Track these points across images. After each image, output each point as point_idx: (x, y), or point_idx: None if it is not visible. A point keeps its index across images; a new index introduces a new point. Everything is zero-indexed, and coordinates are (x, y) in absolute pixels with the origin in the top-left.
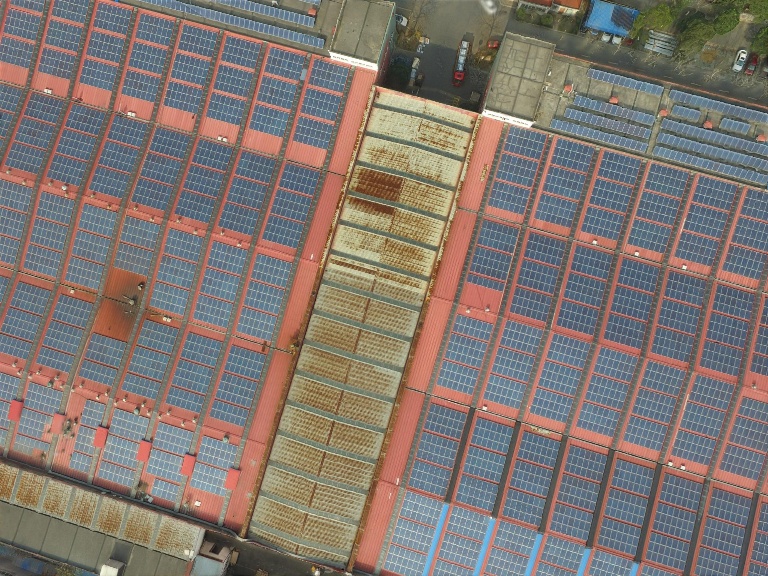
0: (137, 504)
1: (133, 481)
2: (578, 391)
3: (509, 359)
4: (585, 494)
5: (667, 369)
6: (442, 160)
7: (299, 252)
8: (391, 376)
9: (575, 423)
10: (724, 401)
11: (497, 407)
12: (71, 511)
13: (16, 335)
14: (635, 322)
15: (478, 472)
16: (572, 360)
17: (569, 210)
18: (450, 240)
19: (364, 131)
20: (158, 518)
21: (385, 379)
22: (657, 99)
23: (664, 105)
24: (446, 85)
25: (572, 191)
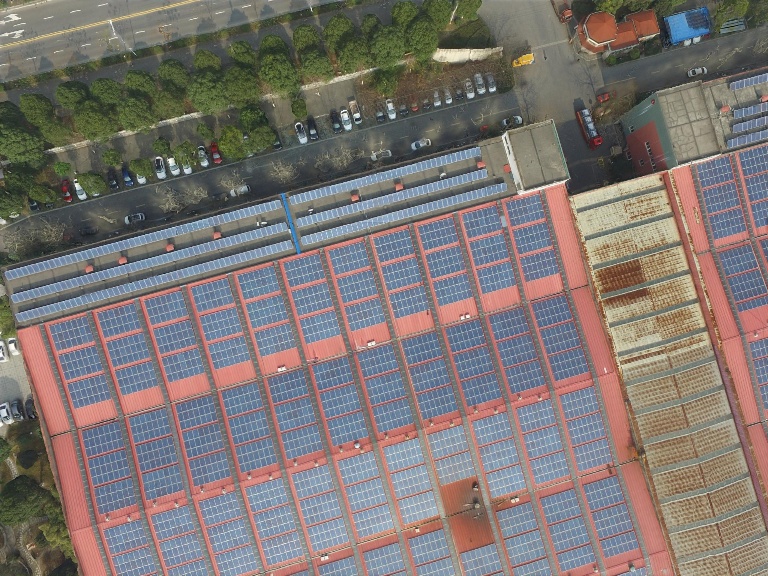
0: None
1: None
2: None
3: None
4: None
5: None
6: (658, 225)
7: (593, 373)
8: (726, 426)
9: None
10: None
11: None
12: None
13: None
14: None
15: None
16: None
17: None
18: None
19: None
20: None
21: (724, 432)
22: None
23: None
24: (585, 153)
25: None
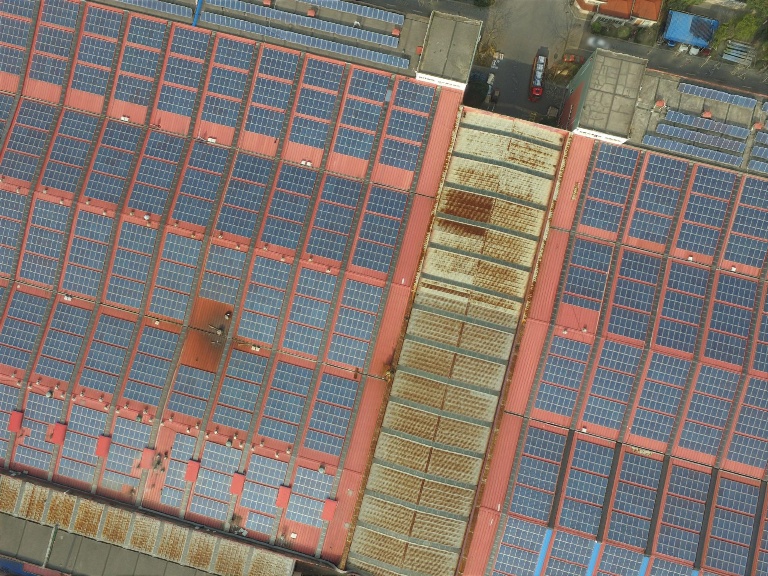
0: (232, 538)
1: (226, 515)
2: (679, 410)
3: (608, 380)
4: (690, 514)
5: None
6: (532, 179)
7: (390, 277)
8: (488, 400)
9: (677, 443)
10: None
11: (597, 428)
12: (160, 546)
13: (101, 369)
14: (735, 339)
15: (580, 495)
16: (672, 379)
17: (663, 227)
18: (543, 260)
19: (451, 152)
20: (250, 551)
21: (482, 403)
22: (750, 112)
23: (757, 118)
24: (522, 100)
25: (666, 207)
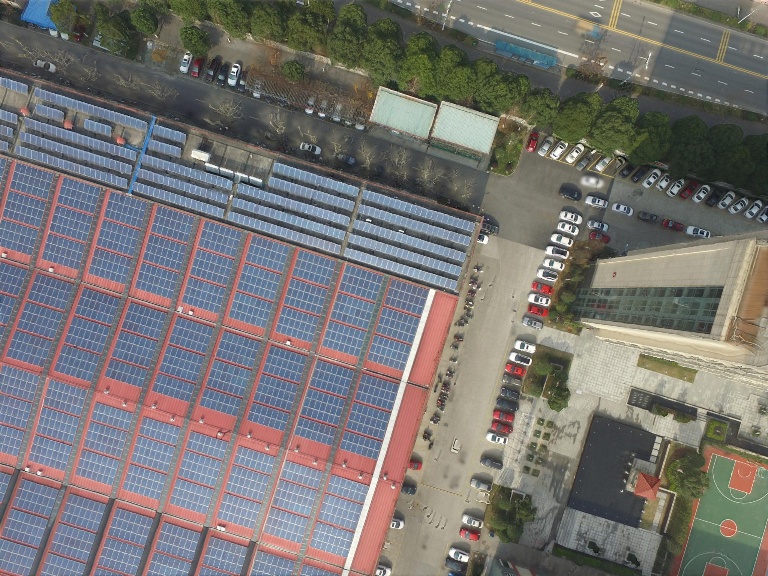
0: None
1: None
2: None
3: None
4: None
5: (21, 373)
6: None
7: None
8: None
9: None
10: (77, 406)
11: None
12: None
13: None
14: None
15: None
16: None
17: None
18: None
19: None
20: None
21: None
22: (26, 97)
23: (33, 103)
24: None
25: None
